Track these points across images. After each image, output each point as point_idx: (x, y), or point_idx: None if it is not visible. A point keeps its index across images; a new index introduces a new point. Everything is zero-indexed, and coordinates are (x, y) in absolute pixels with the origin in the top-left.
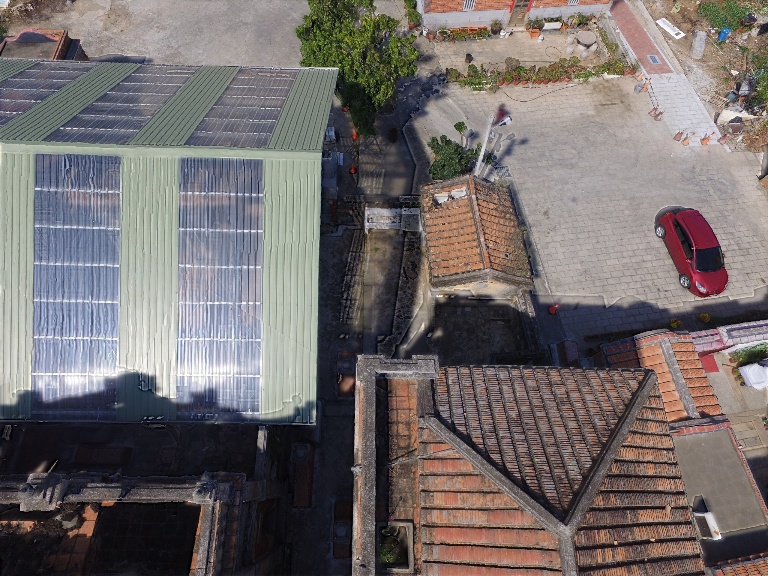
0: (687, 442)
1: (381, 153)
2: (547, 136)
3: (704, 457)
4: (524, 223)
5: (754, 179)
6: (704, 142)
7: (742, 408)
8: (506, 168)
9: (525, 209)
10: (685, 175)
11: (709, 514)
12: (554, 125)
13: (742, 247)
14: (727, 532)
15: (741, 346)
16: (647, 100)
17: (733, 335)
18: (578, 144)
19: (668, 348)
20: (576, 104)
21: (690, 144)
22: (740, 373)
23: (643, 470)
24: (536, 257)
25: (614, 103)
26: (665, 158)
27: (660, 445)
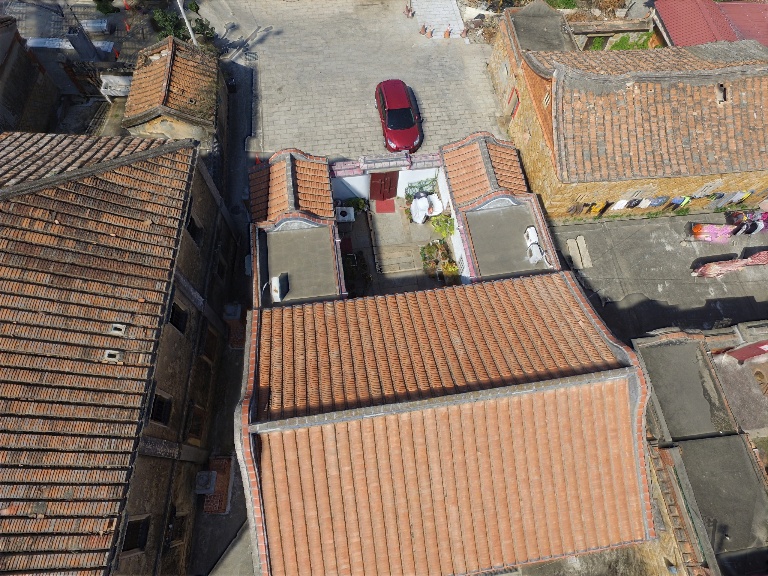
0: (291, 235)
1: (144, 40)
2: (302, 29)
3: (301, 246)
4: (257, 96)
5: (483, 65)
6: (446, 35)
7: (406, 240)
8: (255, 53)
9: (262, 86)
10: (420, 61)
11: (275, 278)
12: (312, 20)
13: (452, 118)
14: (299, 298)
15: (405, 185)
16: (406, 2)
17: (366, 160)
18: (329, 36)
19: (287, 160)
20: (338, 4)
21: (433, 37)
22: (411, 212)
23: (134, 194)
24: (259, 123)
25: (374, 4)
26: (406, 48)
27: (168, 184)
